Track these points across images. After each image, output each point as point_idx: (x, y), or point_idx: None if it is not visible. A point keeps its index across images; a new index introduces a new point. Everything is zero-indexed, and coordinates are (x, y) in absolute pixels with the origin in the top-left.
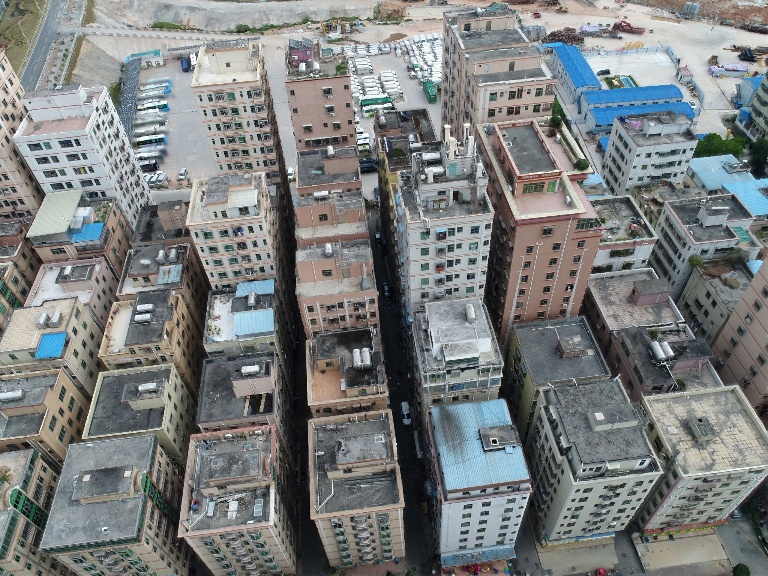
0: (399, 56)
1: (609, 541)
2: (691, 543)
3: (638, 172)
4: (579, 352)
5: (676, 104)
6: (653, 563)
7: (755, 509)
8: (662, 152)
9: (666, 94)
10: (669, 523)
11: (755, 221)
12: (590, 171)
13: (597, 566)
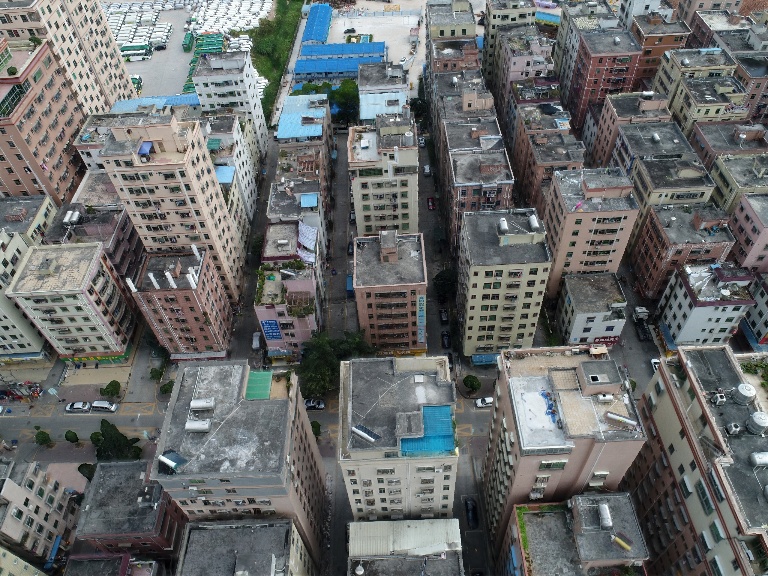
0: (188, 11)
1: (50, 366)
2: (109, 371)
3: (206, 100)
4: (17, 217)
5: (371, 58)
6: (71, 382)
7: (163, 350)
8: (216, 82)
9: (370, 49)
10: (70, 348)
11: (286, 143)
12: (16, 76)
13: (28, 380)
